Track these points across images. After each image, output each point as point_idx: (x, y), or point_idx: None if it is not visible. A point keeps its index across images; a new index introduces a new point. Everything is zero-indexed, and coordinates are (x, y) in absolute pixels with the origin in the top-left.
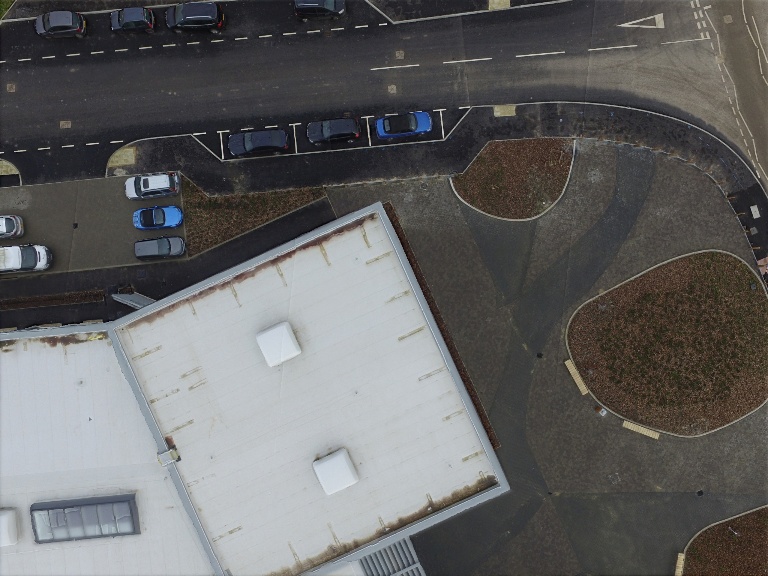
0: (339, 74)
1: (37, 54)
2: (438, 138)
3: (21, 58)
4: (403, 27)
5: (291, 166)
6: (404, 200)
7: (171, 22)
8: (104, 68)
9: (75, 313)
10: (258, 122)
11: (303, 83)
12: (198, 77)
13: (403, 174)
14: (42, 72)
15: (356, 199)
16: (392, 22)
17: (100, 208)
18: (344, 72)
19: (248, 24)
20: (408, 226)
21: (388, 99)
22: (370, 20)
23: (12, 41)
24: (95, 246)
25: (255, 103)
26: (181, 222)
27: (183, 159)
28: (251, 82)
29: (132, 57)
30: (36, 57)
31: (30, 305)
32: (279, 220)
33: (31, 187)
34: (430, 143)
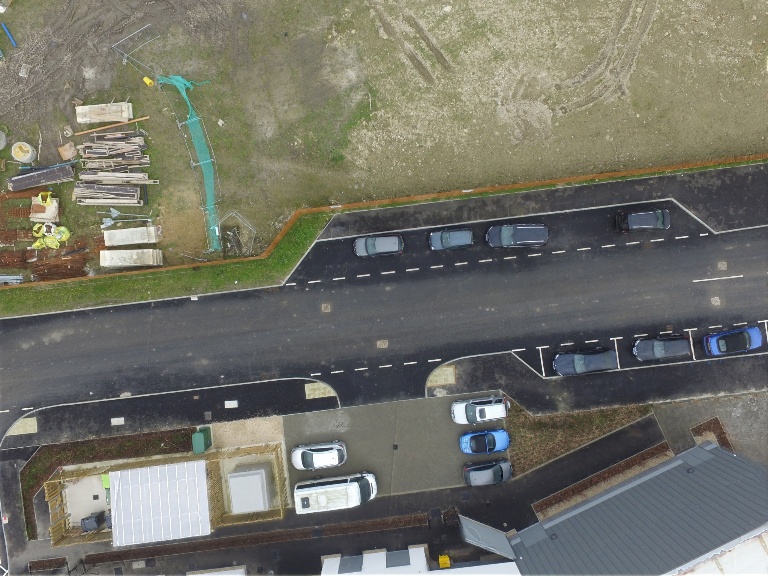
0: (660, 286)
1: (351, 273)
2: (765, 350)
3: (335, 277)
4: (725, 237)
5: (615, 382)
6: (732, 415)
7: (496, 243)
8: (420, 285)
9: (399, 538)
10: (578, 337)
11: (623, 296)
12: (516, 292)
13: (731, 389)
14: (357, 291)
15: (683, 415)
16: (714, 232)
17: (420, 429)
18: (665, 284)
19: (565, 237)
20: (736, 441)
21: (712, 311)
22: (691, 230)
23: (326, 260)
24: (416, 468)
25: (575, 317)
26: (508, 445)
27: (504, 377)
28: (570, 296)
29: (448, 273)
30: (351, 276)
31: (353, 531)
32: (605, 438)
33: (349, 409)
34: (757, 356)
